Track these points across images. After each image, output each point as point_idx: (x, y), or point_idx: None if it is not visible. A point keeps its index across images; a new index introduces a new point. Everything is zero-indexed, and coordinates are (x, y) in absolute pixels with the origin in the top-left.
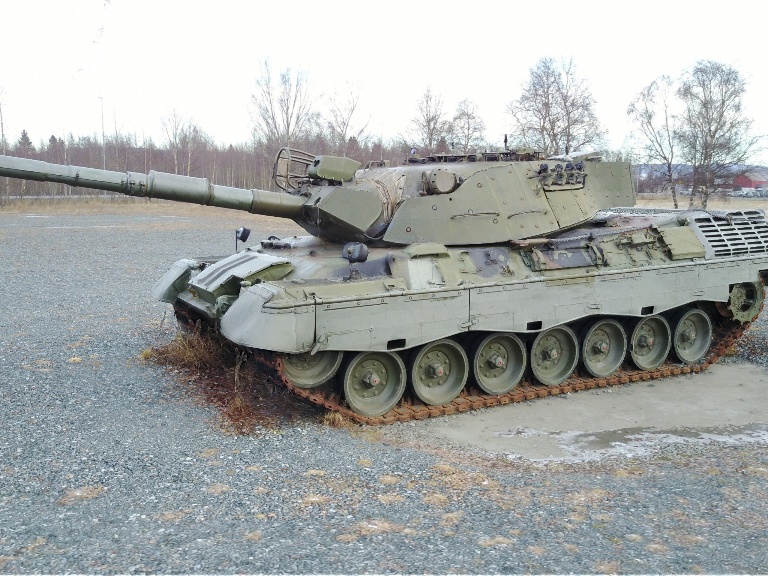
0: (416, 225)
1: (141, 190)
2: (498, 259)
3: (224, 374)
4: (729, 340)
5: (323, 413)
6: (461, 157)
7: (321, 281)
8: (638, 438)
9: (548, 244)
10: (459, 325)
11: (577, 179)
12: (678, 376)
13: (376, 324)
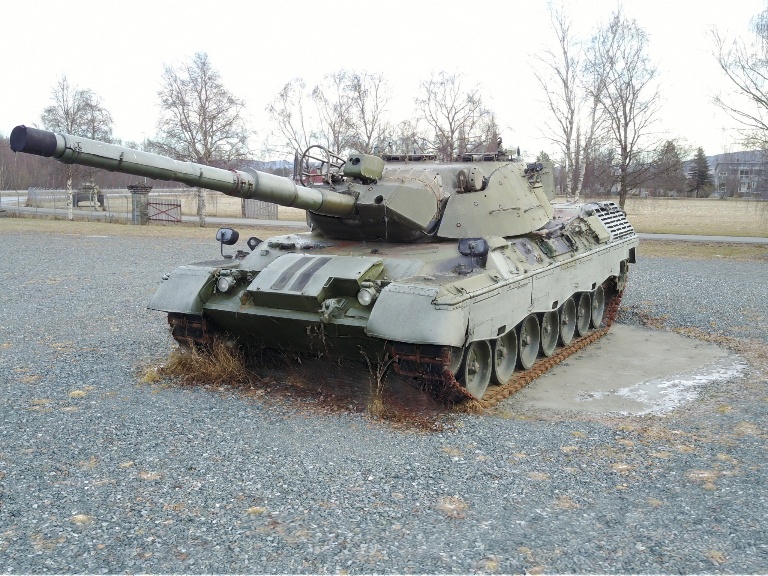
0: (464, 220)
1: (249, 190)
2: None
3: (269, 385)
4: (614, 306)
5: (458, 403)
6: (424, 156)
7: (445, 277)
8: (669, 386)
9: (549, 234)
10: (527, 309)
11: None
12: (600, 339)
13: (495, 313)
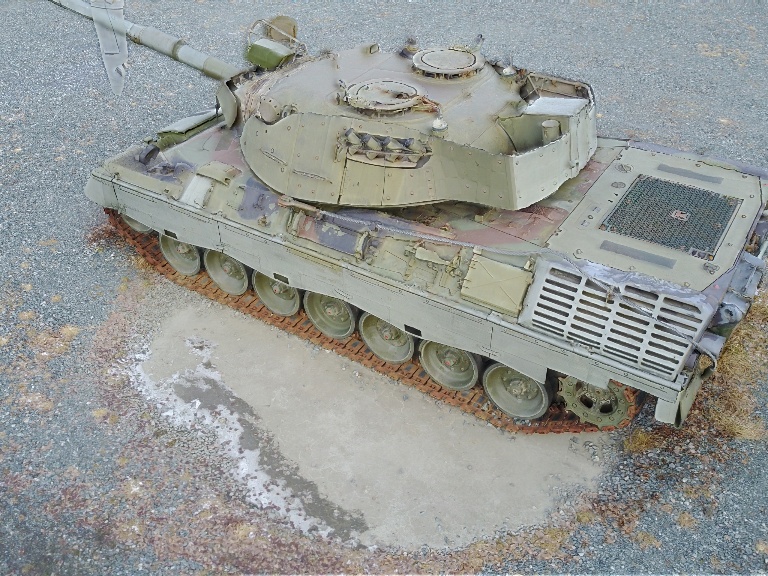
0: None
1: (136, 41)
2: (268, 206)
3: None
4: (562, 425)
5: None
6: (418, 69)
7: None
8: (218, 412)
9: None
10: (214, 244)
11: (407, 156)
12: (464, 413)
13: None
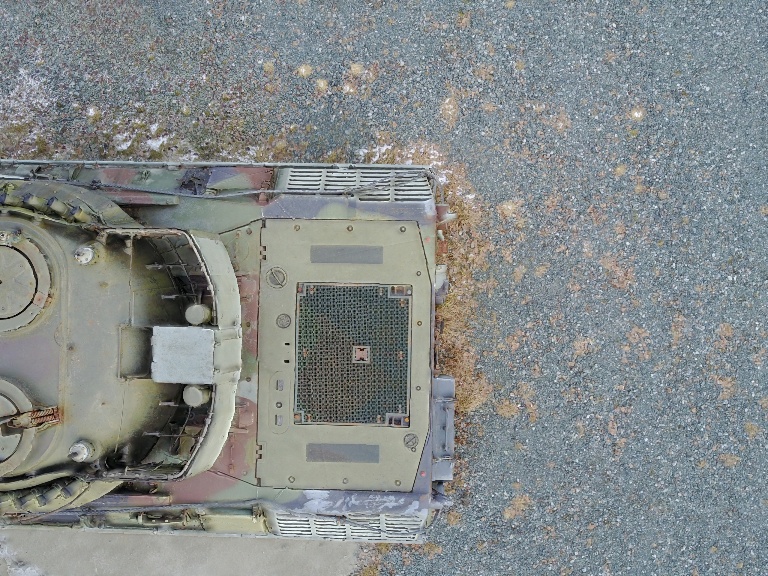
0: None
1: None
2: None
3: None
4: None
5: None
6: None
7: None
8: None
9: None
10: None
11: None
12: None
13: None
